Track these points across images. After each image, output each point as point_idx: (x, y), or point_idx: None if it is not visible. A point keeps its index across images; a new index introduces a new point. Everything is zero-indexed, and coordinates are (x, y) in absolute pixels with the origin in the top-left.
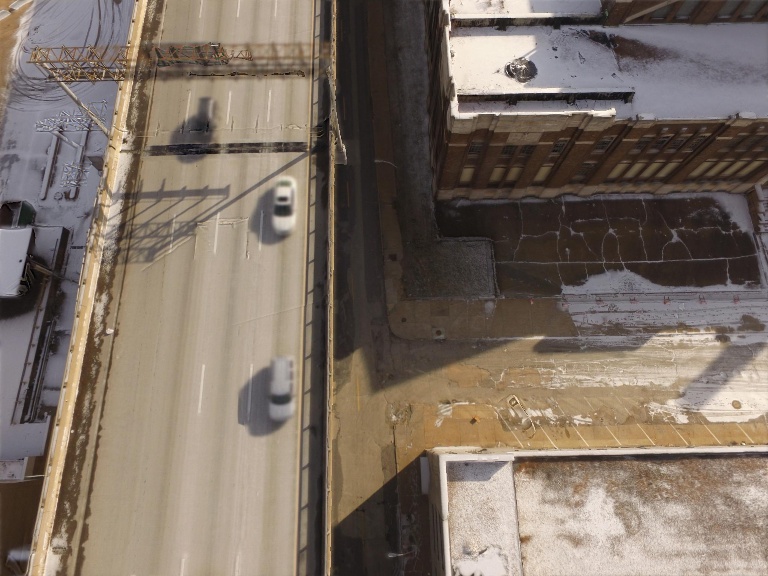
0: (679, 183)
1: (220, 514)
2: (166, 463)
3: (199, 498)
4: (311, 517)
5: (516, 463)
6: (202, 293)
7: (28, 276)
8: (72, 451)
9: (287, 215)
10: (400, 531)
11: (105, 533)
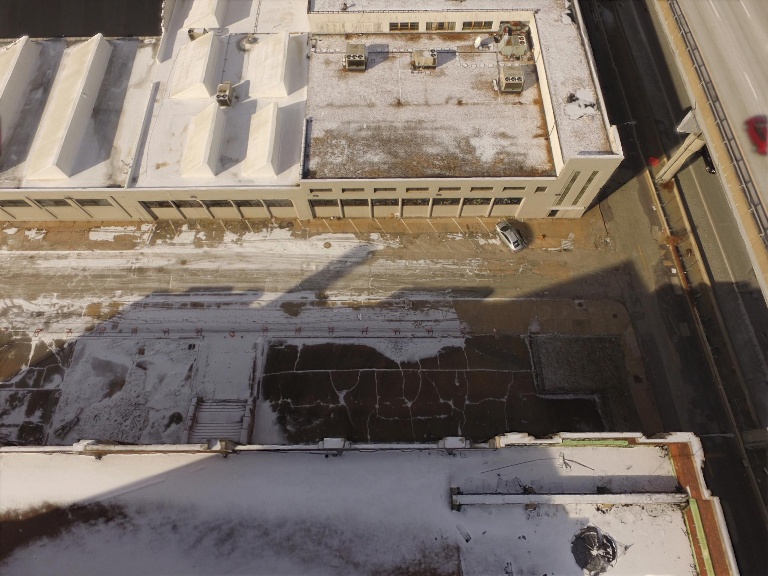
0: None
1: None
2: None
3: None
4: None
5: (545, 175)
6: None
7: None
8: None
9: None
10: None
11: None
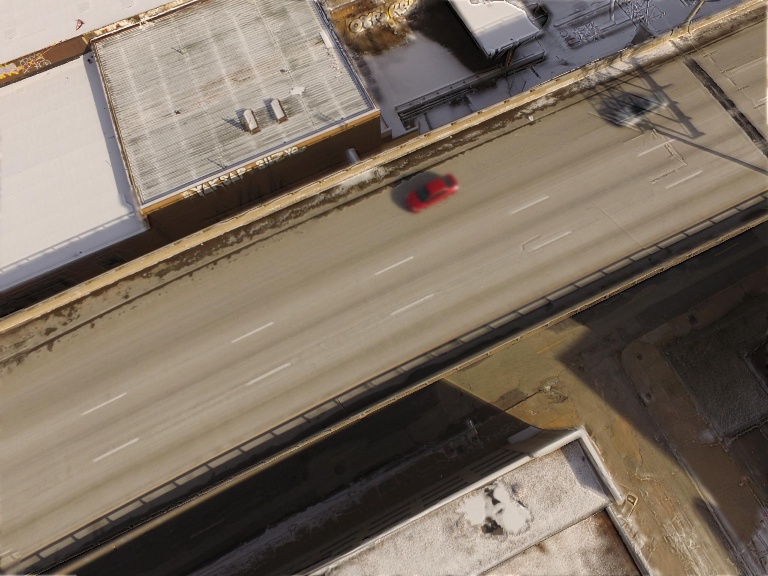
0: None
1: (454, 266)
2: (466, 210)
3: (456, 246)
4: (487, 336)
5: (600, 514)
6: (601, 164)
7: (502, 51)
8: (439, 144)
9: (713, 193)
10: (462, 434)
11: (402, 196)
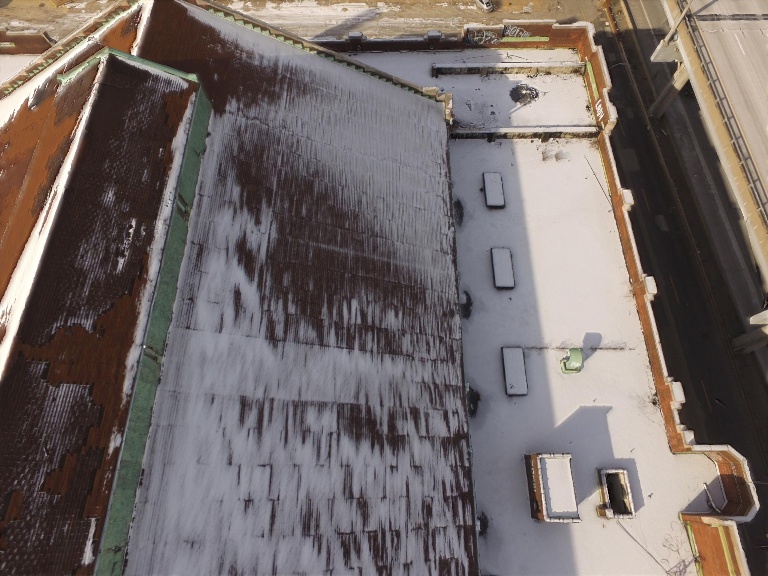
0: None
1: None
2: None
3: None
4: None
5: None
6: None
7: None
8: None
9: None
10: None
11: None
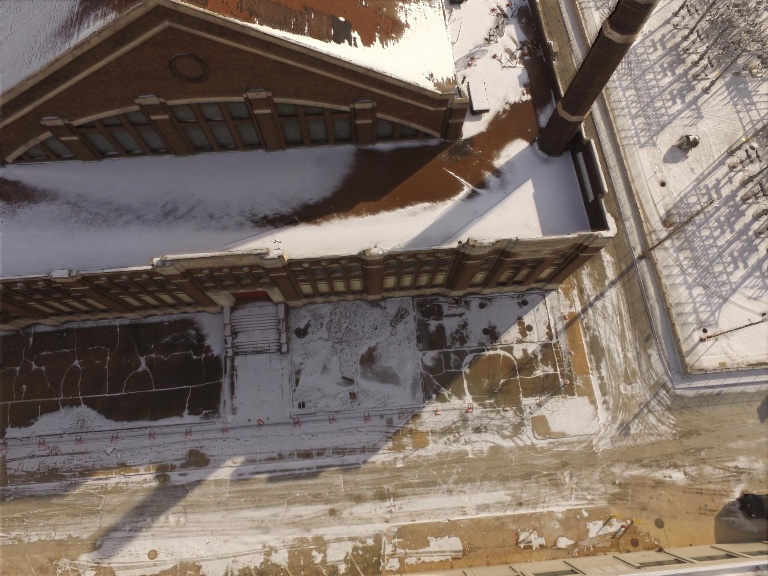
0: (137, 311)
1: None
2: None
3: None
4: None
5: None
6: None
7: None
8: None
9: None
10: None
11: None
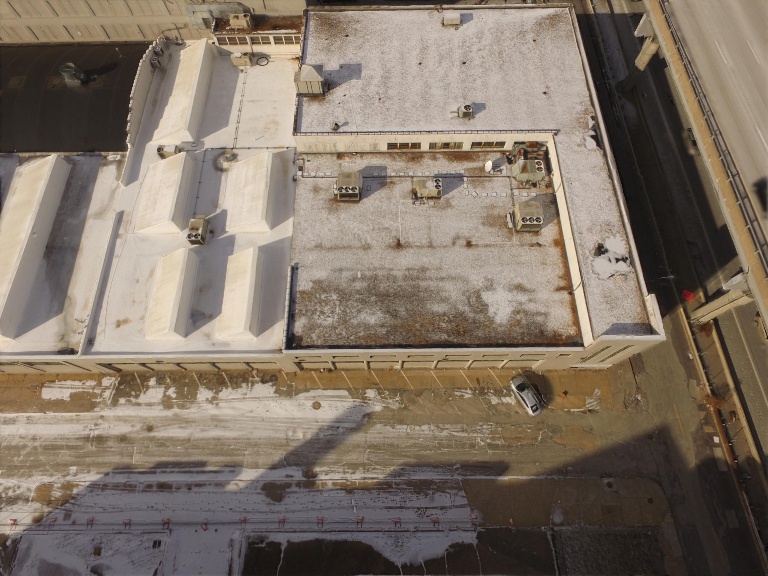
0: None
1: None
2: None
3: None
4: None
5: (570, 343)
6: None
7: None
8: None
9: None
10: None
11: None
